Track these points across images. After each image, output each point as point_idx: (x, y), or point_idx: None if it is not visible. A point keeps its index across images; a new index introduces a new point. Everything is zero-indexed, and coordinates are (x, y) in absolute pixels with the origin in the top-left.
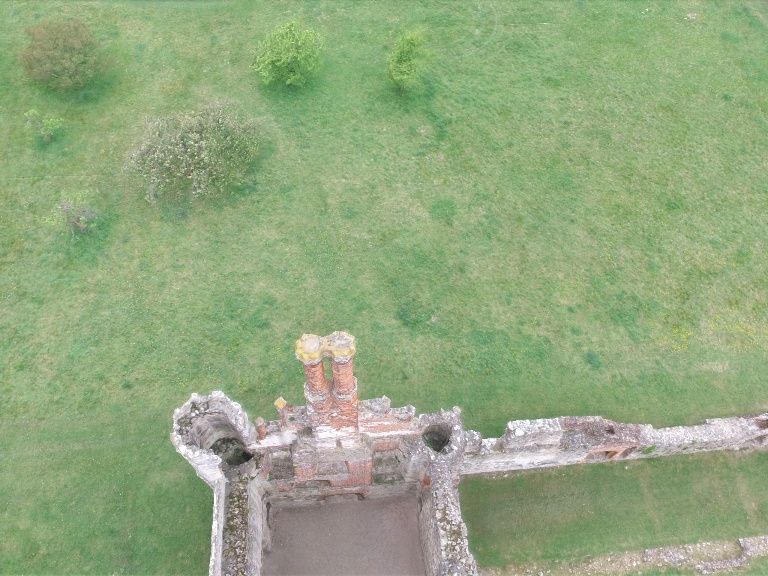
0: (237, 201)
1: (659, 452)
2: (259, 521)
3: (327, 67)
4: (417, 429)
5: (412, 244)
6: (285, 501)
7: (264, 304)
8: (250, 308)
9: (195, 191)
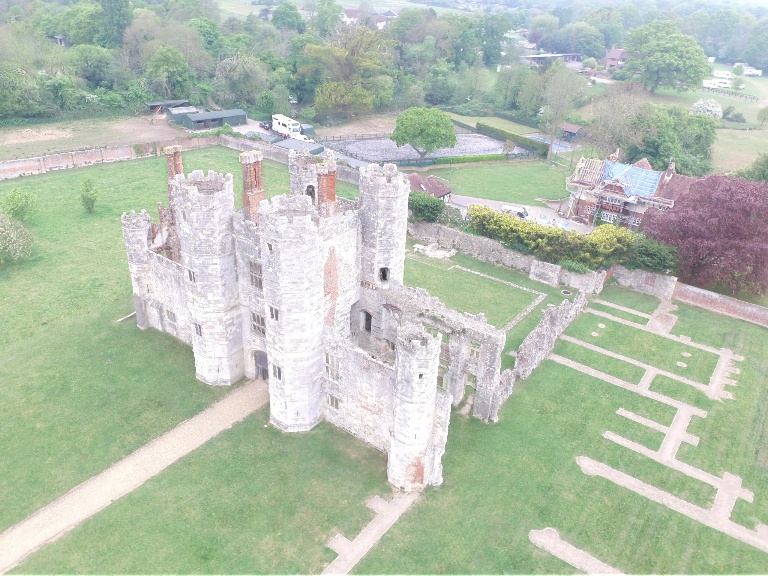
0: (37, 264)
1: None
2: None
3: (38, 218)
4: None
5: None
6: None
7: (93, 281)
8: (87, 284)
9: (15, 255)
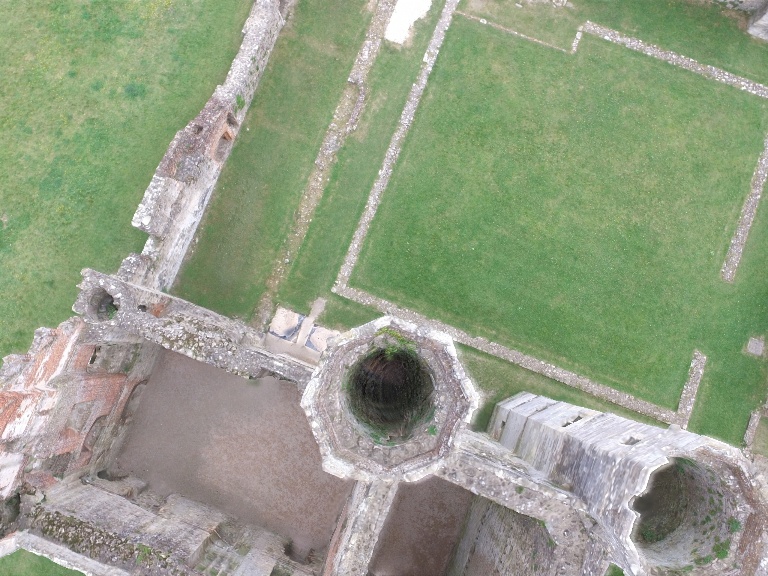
0: None
1: (249, 93)
2: (101, 497)
3: None
4: (75, 327)
5: None
6: (107, 456)
7: None
8: None
9: None
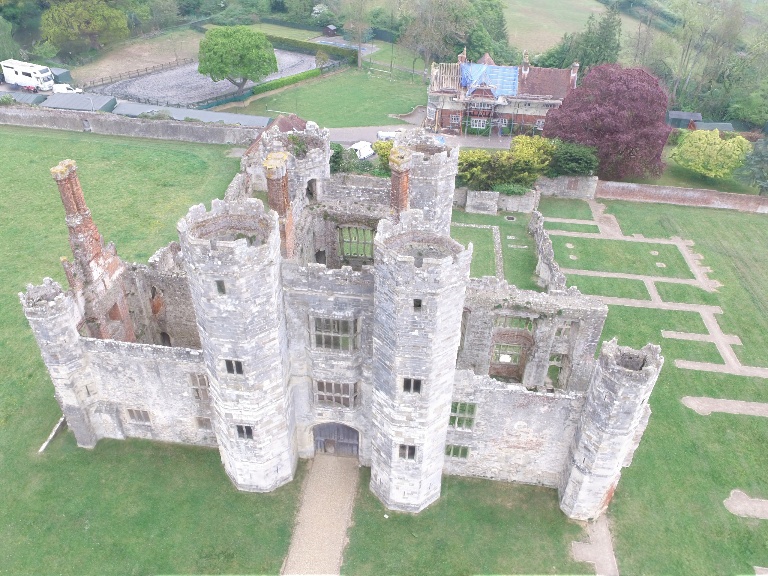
0: None
1: None
2: None
3: None
4: (123, 264)
5: None
6: None
7: None
8: None
9: None
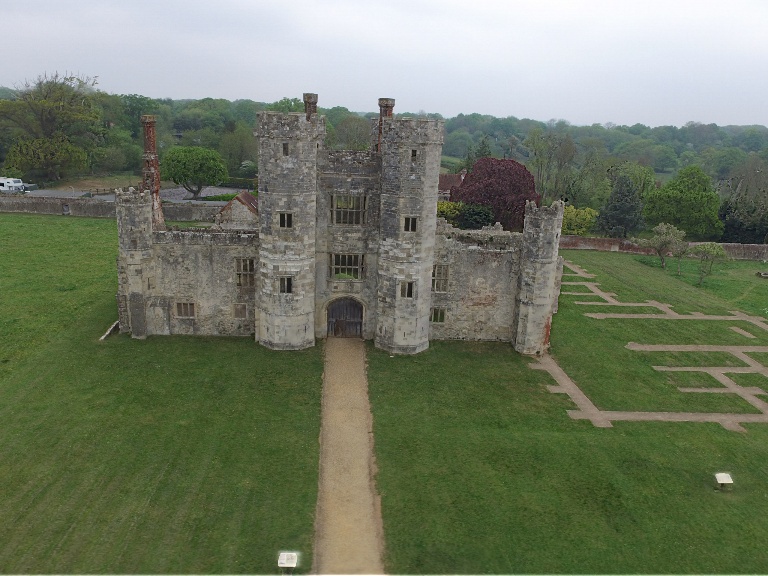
0: None
1: None
2: None
3: None
4: None
5: (12, 284)
6: None
7: None
8: None
9: None
